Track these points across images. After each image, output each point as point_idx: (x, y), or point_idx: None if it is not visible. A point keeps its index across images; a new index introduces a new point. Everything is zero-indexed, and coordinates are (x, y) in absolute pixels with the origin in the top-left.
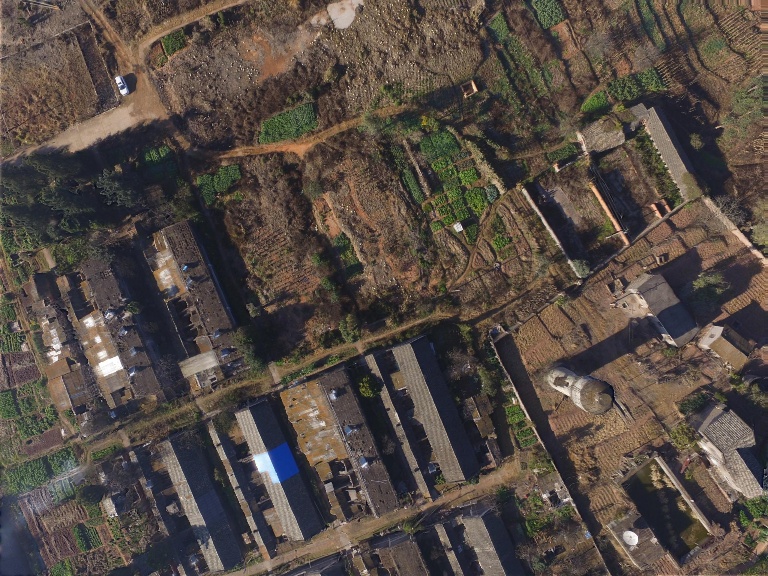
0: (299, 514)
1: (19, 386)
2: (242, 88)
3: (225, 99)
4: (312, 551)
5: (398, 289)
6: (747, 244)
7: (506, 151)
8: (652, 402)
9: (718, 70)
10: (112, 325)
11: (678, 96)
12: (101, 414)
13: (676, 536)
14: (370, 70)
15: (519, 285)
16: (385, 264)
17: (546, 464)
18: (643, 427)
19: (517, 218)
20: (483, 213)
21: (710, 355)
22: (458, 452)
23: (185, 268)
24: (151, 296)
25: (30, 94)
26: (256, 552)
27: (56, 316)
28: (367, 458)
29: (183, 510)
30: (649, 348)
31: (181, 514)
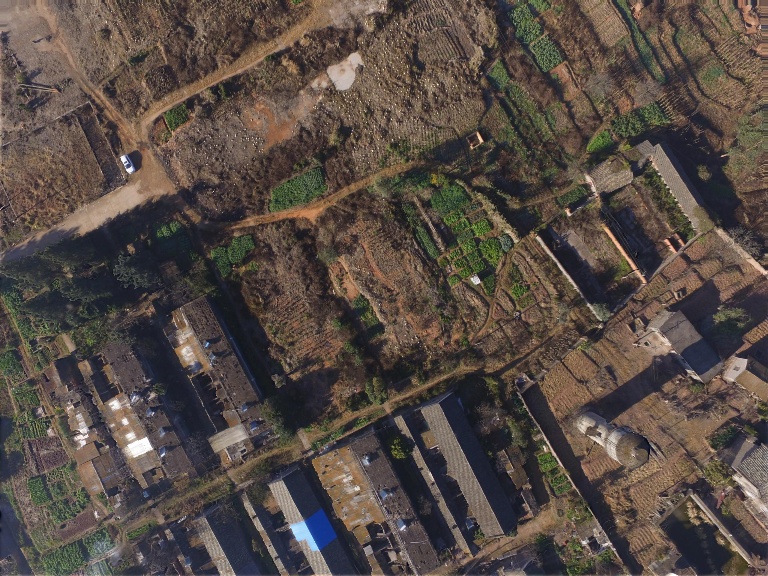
0: None
1: (48, 471)
2: (248, 158)
3: (232, 170)
4: None
5: (421, 346)
6: (763, 272)
7: (517, 201)
8: (682, 439)
9: (718, 97)
10: (138, 407)
11: (682, 128)
12: (134, 495)
13: (717, 570)
14: (375, 129)
15: (541, 333)
16: (406, 323)
17: (584, 513)
18: (676, 465)
19: (533, 265)
20: (499, 263)
21: (736, 387)
22: (495, 507)
23: (207, 345)
24: (174, 372)
25: (36, 179)
26: None
27: (81, 401)
28: (405, 520)
29: None
30: (675, 385)
31: None
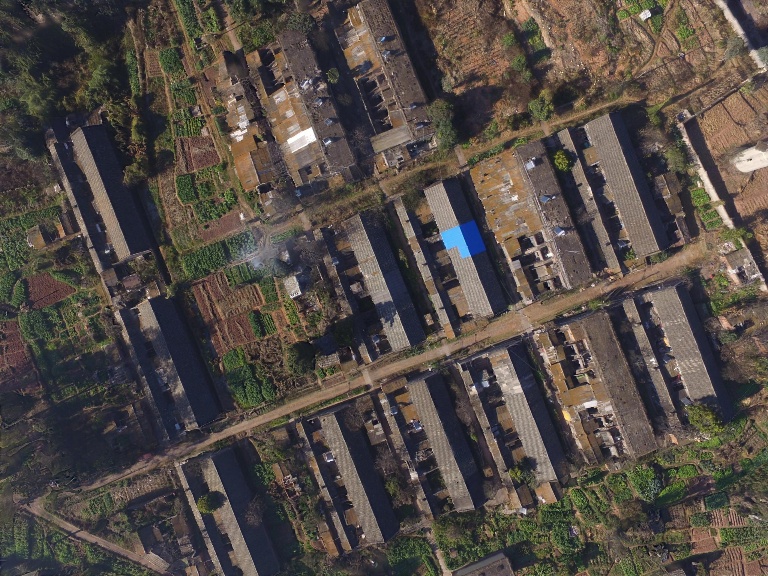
0: (488, 289)
1: (198, 170)
2: None
3: None
4: (492, 335)
5: (586, 73)
6: None
7: None
8: None
9: None
10: (307, 96)
11: None
12: (286, 192)
13: None
14: None
15: (705, 72)
16: (573, 49)
17: (744, 231)
18: None
19: (700, 10)
20: (667, 5)
21: None
22: (652, 224)
23: (383, 39)
24: None
25: None
26: (435, 336)
27: (244, 93)
28: (562, 228)
29: (365, 291)
30: None
31: (363, 295)
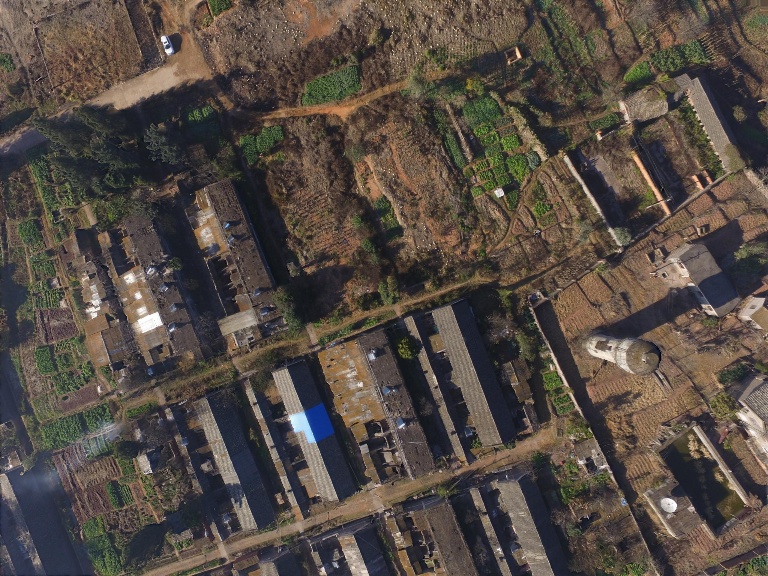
0: (334, 475)
1: (57, 342)
2: (287, 50)
3: (269, 60)
4: (345, 513)
5: (438, 253)
6: None
7: (550, 117)
8: (691, 372)
9: (761, 44)
10: (153, 281)
11: (721, 68)
12: (138, 371)
13: (712, 507)
14: (415, 34)
15: (559, 252)
16: (425, 228)
17: (585, 429)
18: (681, 396)
19: (558, 185)
20: (524, 179)
21: (750, 326)
22: (496, 416)
23: (227, 226)
24: (190, 255)
25: (75, 52)
26: (288, 513)
27: (96, 272)
28: (404, 419)
29: (217, 469)
30: (688, 318)
31: (215, 473)
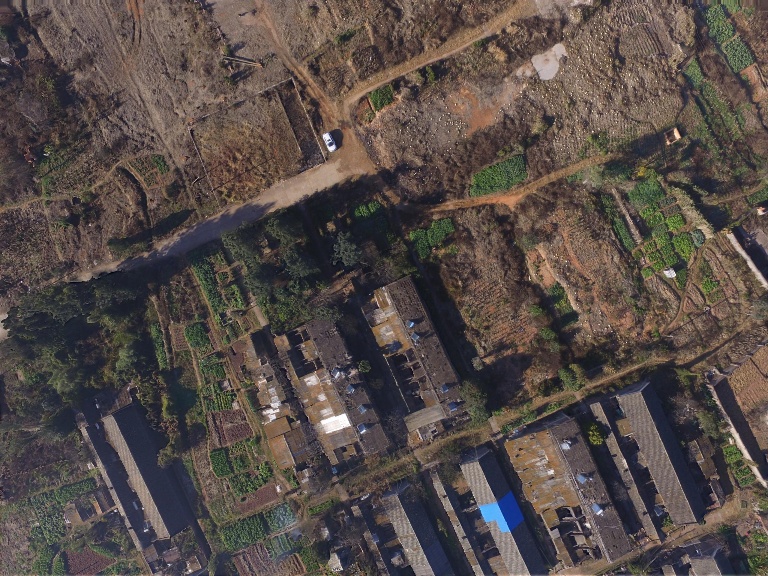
0: (528, 561)
1: (231, 444)
2: (451, 142)
3: (435, 153)
4: None
5: (614, 336)
6: None
7: (716, 197)
8: None
9: None
10: (339, 383)
11: None
12: (322, 470)
13: None
14: (577, 120)
15: (731, 328)
16: (600, 312)
17: None
18: None
19: (724, 261)
20: (690, 258)
21: None
22: (688, 495)
23: (412, 325)
24: (364, 350)
25: (234, 152)
26: None
27: (275, 375)
28: (600, 505)
29: (406, 561)
30: None
31: (404, 565)
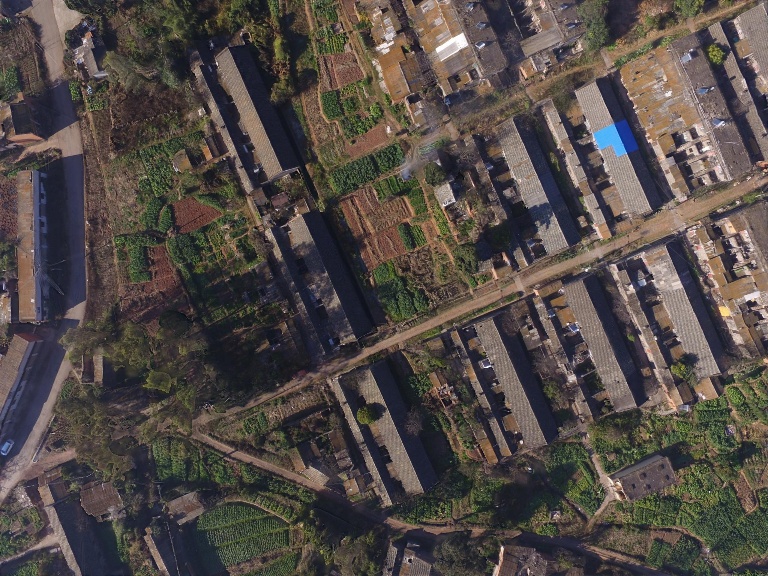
0: (644, 186)
1: (342, 86)
2: None
3: None
4: (645, 235)
5: None
6: None
7: None
8: None
9: None
10: (458, 1)
11: None
12: None
13: None
14: None
15: None
16: None
17: None
18: None
19: None
20: None
21: None
22: None
23: None
24: None
25: None
26: (587, 239)
27: (390, 5)
28: (720, 119)
29: (517, 196)
30: None
31: (515, 201)
